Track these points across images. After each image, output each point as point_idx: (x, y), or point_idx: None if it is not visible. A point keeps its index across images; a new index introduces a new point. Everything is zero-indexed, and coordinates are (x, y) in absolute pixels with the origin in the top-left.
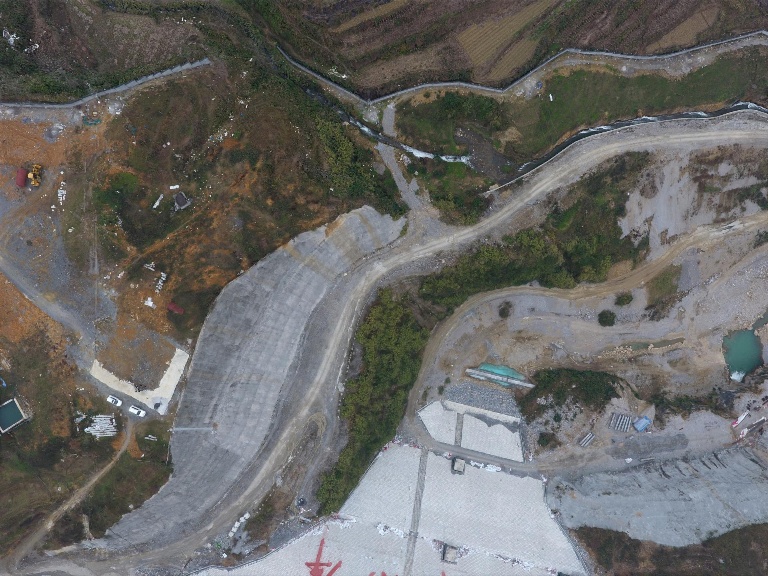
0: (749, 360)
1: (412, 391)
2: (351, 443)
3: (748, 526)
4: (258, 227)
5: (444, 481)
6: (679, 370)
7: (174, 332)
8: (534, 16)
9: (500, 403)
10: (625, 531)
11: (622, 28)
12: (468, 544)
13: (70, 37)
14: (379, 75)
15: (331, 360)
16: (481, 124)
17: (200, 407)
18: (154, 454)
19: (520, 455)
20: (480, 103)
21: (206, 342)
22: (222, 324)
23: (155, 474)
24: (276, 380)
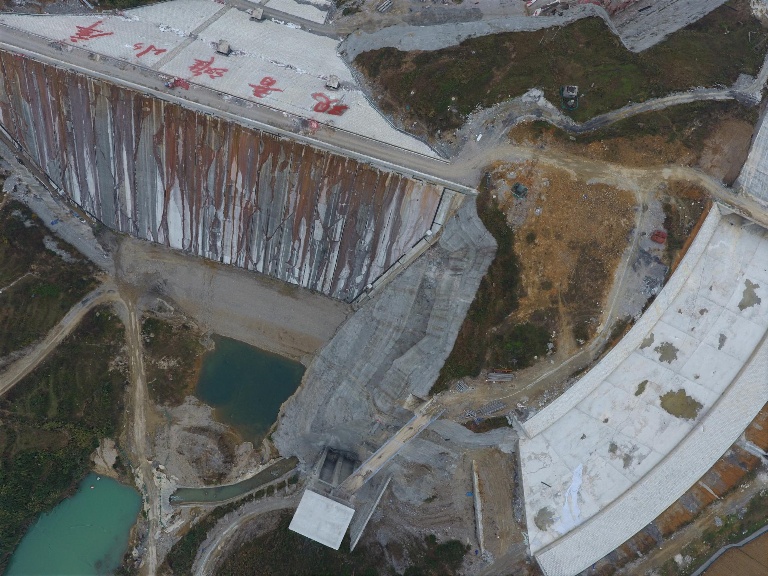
0: None
1: None
2: None
3: (505, 31)
4: None
5: (239, 21)
6: None
7: None
8: None
9: None
10: (396, 47)
11: None
12: (245, 49)
13: None
14: None
15: None
16: None
17: None
18: None
19: (322, 20)
20: None
21: None
22: None
23: None
24: None
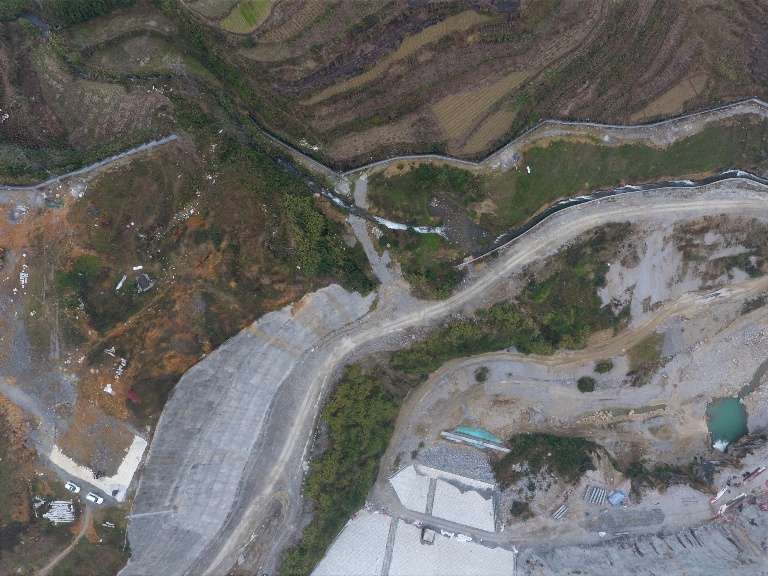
0: (733, 428)
1: (384, 457)
2: (315, 521)
3: None
4: (221, 309)
5: (413, 552)
6: (660, 438)
7: (133, 419)
8: (512, 87)
9: (474, 468)
10: None
11: (605, 97)
12: None
13: (40, 106)
14: (351, 147)
15: (296, 438)
16: (457, 194)
17: (159, 492)
18: (112, 540)
19: (492, 525)
20: (455, 175)
21: (165, 429)
22: (182, 409)
23: (113, 559)
24: (240, 458)
